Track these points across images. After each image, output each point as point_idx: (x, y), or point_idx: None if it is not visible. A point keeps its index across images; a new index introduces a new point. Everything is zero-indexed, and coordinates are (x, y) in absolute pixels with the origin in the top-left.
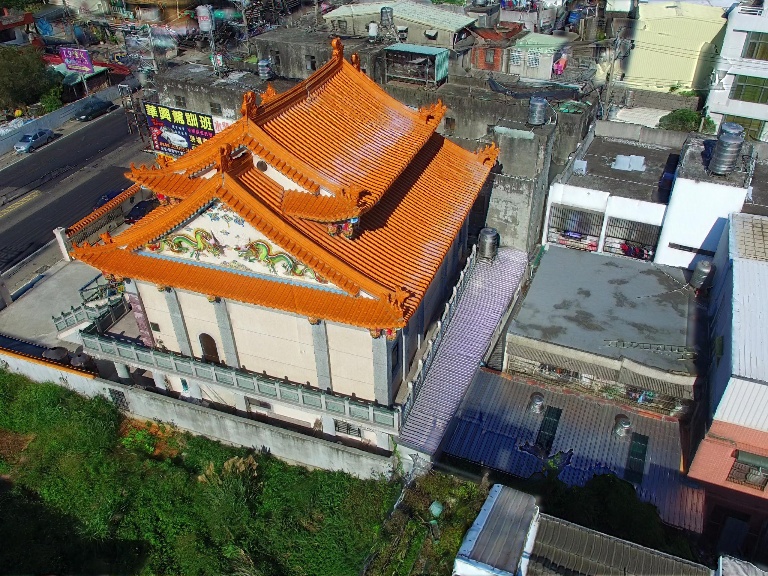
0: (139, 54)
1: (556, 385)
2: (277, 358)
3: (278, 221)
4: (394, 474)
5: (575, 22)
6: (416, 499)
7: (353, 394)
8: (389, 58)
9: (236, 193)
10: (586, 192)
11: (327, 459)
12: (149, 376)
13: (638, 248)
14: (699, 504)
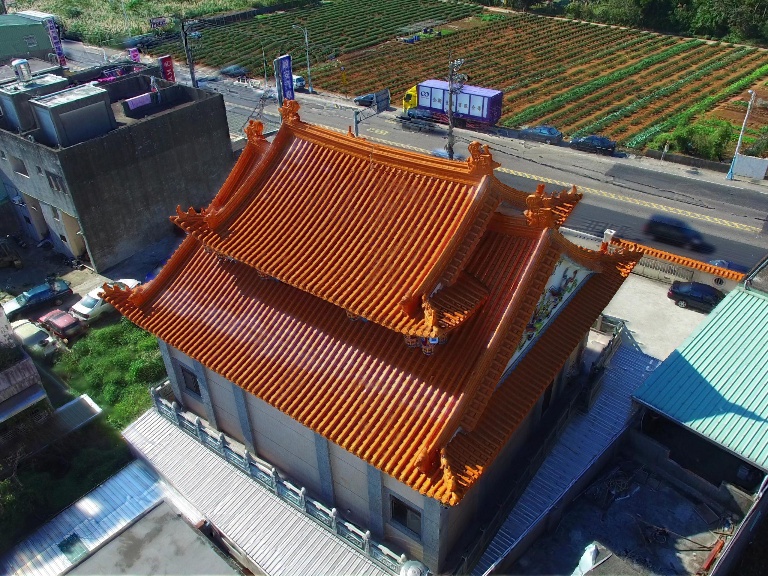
0: None
1: None
2: None
3: None
4: None
5: None
6: None
7: None
8: None
9: None
10: None
11: None
12: None
13: None
14: None
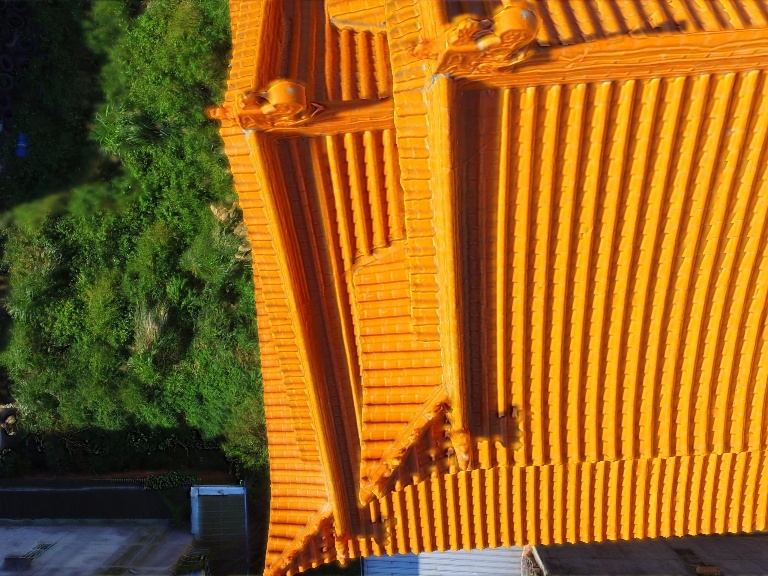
0: None
1: None
2: None
3: (290, 295)
4: None
5: None
6: None
7: None
8: None
9: None
10: None
11: None
12: None
13: None
14: None
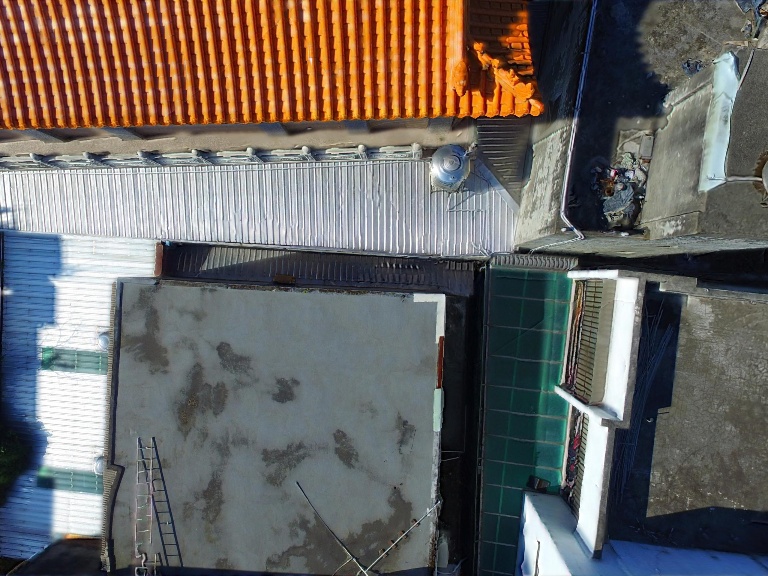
0: None
1: None
2: None
3: None
4: None
5: None
6: None
7: None
8: None
9: None
10: None
11: None
12: None
13: (574, 469)
14: (31, 554)
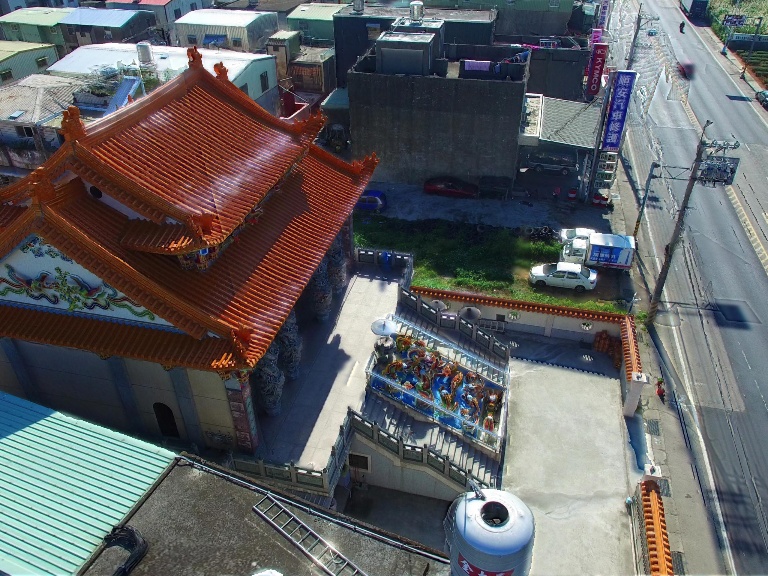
0: None
1: None
2: None
3: None
4: None
5: None
6: None
7: None
8: None
9: None
10: None
11: None
12: None
13: None
14: None
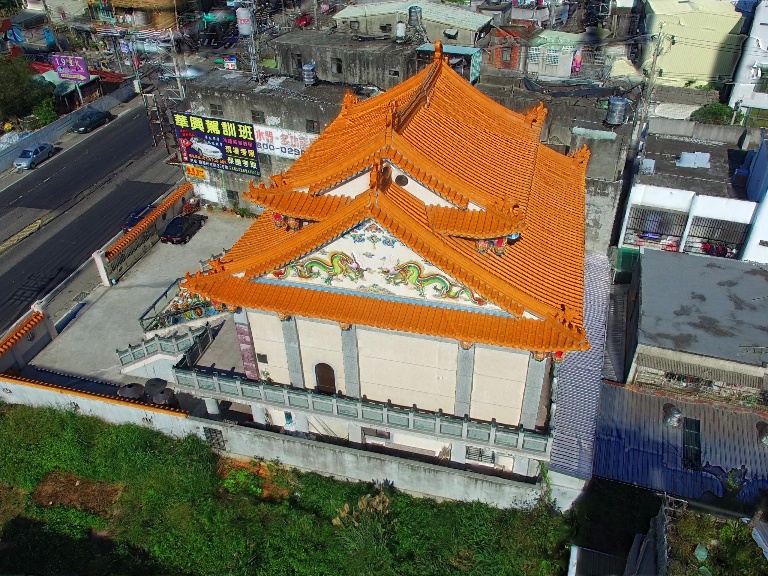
0: (159, 61)
1: (687, 395)
2: (407, 386)
3: (436, 240)
4: (540, 501)
5: (608, 18)
6: (677, 544)
7: (493, 419)
8: (422, 59)
9: (390, 212)
10: (669, 192)
11: (462, 490)
12: (237, 409)
13: (721, 247)
14: None
